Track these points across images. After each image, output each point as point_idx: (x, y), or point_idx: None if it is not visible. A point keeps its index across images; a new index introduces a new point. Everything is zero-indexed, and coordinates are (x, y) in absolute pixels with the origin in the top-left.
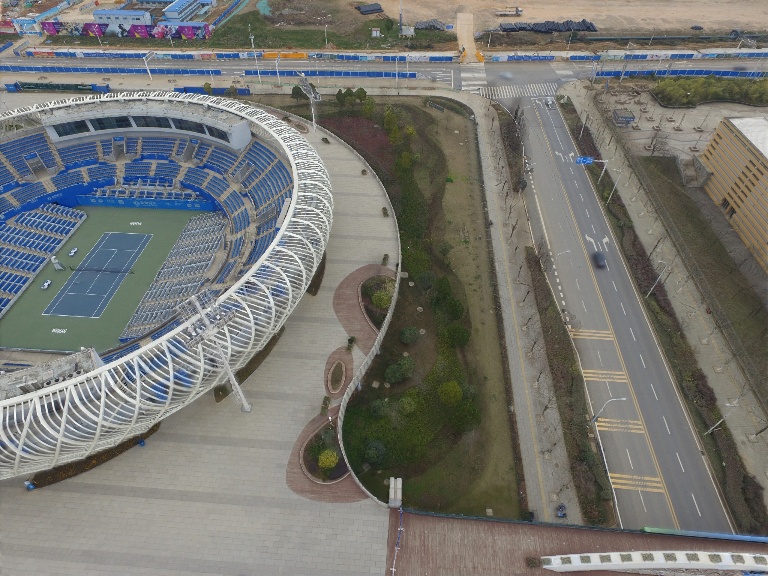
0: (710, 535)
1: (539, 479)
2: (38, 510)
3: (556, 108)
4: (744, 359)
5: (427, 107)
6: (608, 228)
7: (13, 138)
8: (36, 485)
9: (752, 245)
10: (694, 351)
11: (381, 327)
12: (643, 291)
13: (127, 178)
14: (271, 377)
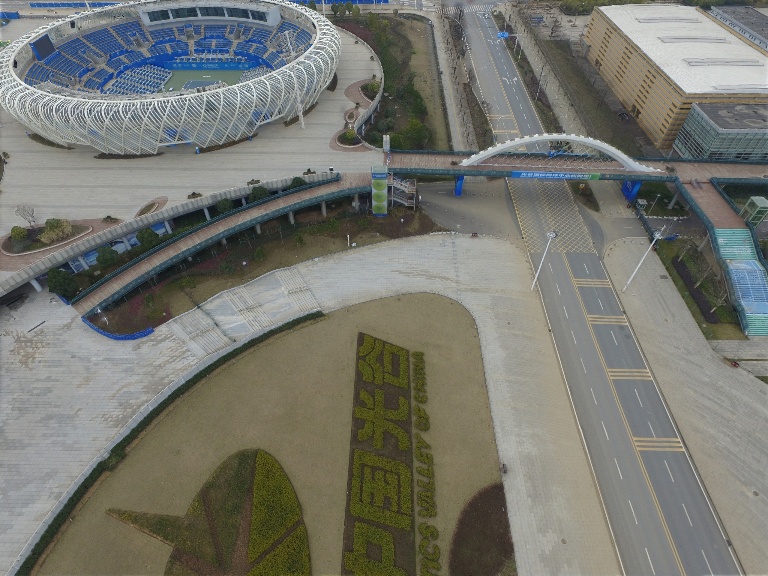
0: (540, 153)
1: None
2: (204, 159)
3: (491, 18)
4: (586, 120)
5: (397, 17)
6: (517, 74)
7: (119, 23)
8: (200, 152)
9: (609, 81)
10: (557, 116)
11: None
12: (534, 98)
13: (197, 50)
14: (314, 119)
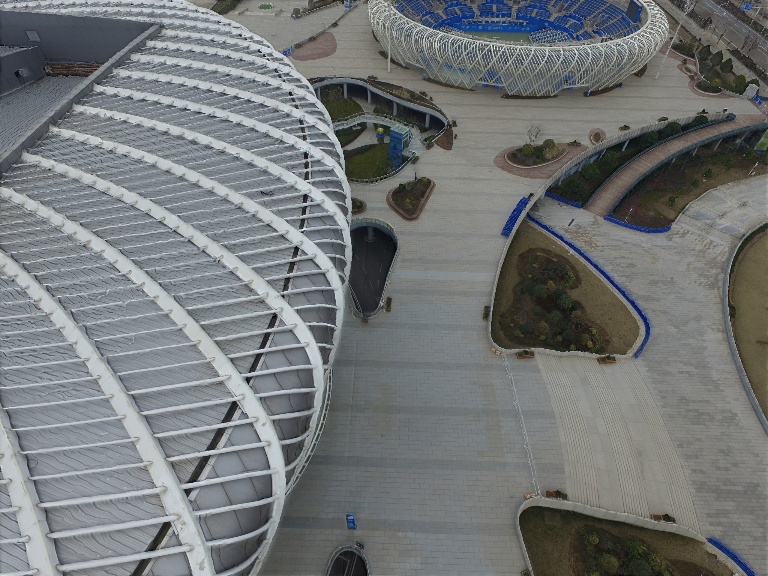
0: None
1: None
2: None
3: None
4: None
5: None
6: (767, 42)
7: None
8: (589, 95)
9: None
10: None
11: (694, 58)
12: None
13: (481, 14)
14: None
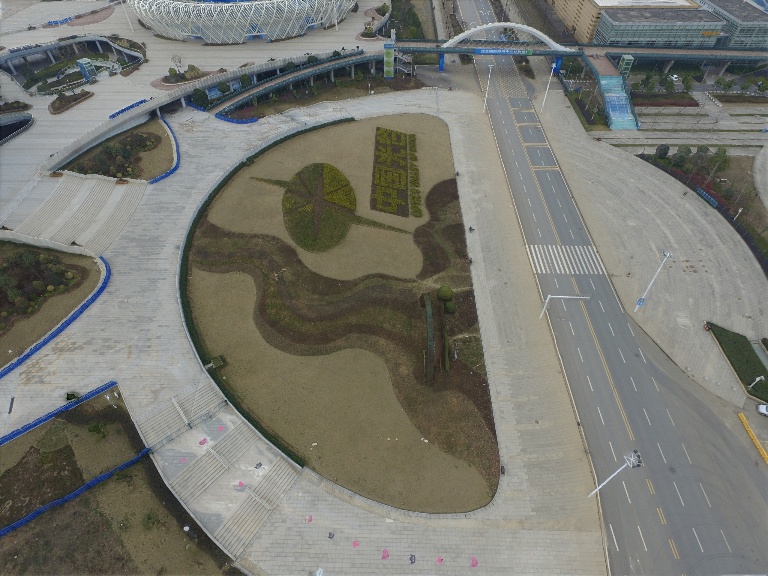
0: (495, 40)
1: (447, 57)
2: (274, 45)
3: None
4: None
5: None
6: (491, 9)
7: None
8: (270, 42)
9: (559, 13)
10: None
11: (385, 16)
12: None
13: None
14: (344, 26)
